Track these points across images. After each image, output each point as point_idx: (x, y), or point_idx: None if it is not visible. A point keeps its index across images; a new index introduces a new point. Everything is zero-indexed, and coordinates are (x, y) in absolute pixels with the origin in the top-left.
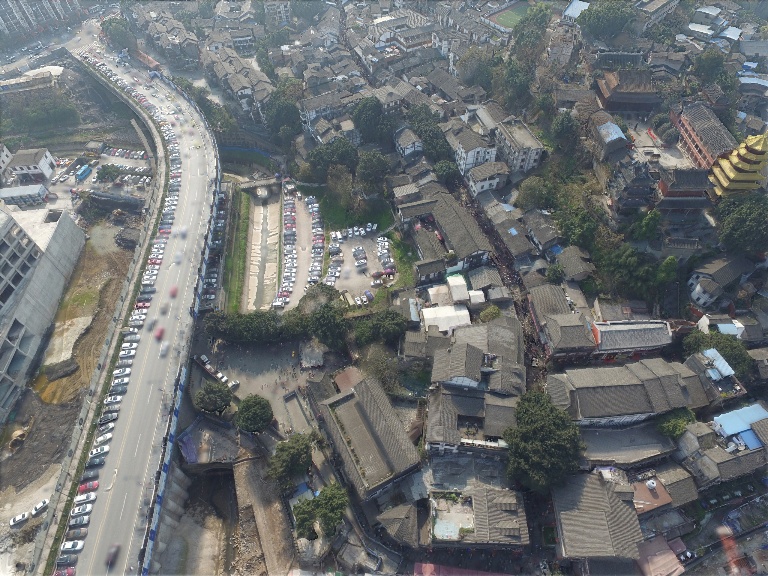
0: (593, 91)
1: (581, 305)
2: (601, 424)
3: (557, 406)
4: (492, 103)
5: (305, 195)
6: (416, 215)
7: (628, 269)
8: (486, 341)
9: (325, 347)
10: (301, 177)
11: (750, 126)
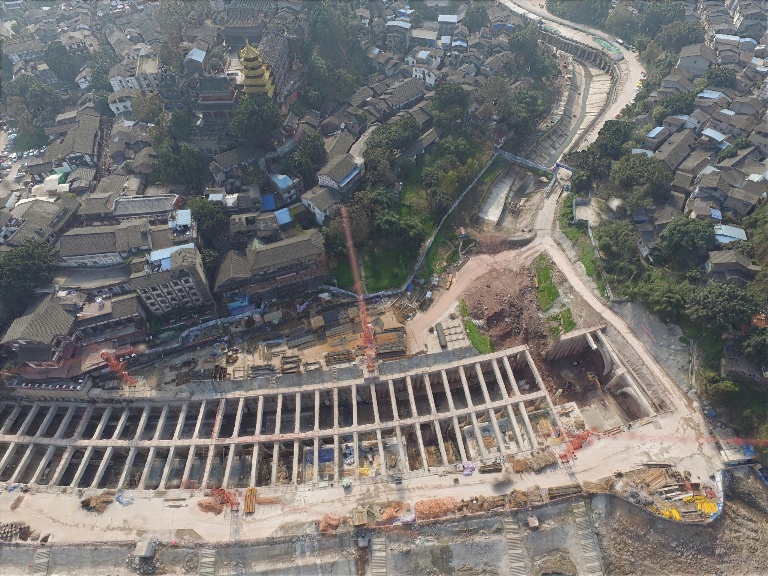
0: (216, 28)
1: (132, 189)
2: (90, 266)
3: (52, 252)
4: (155, 43)
5: (12, 128)
6: (58, 132)
7: (165, 158)
8: (26, 211)
9: None
10: (1, 111)
11: (378, 60)
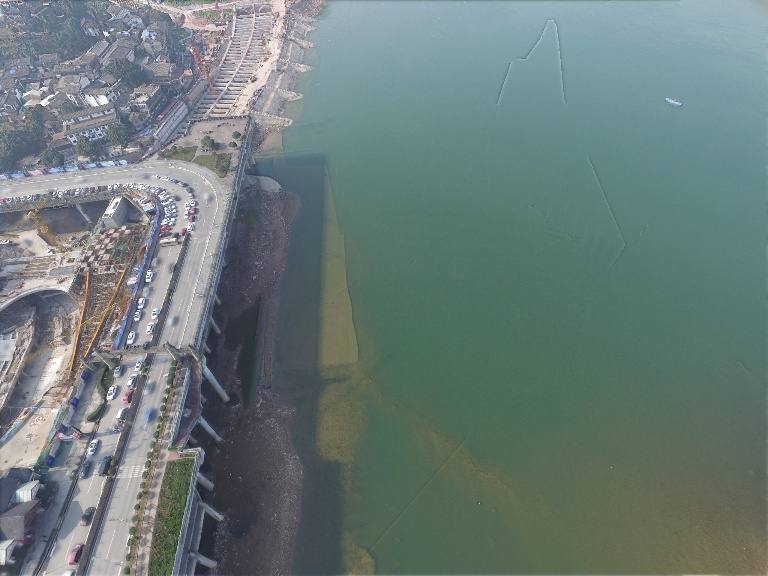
0: None
1: None
2: None
3: None
4: None
5: None
6: None
7: (66, 40)
8: None
9: (30, 157)
10: None
11: None
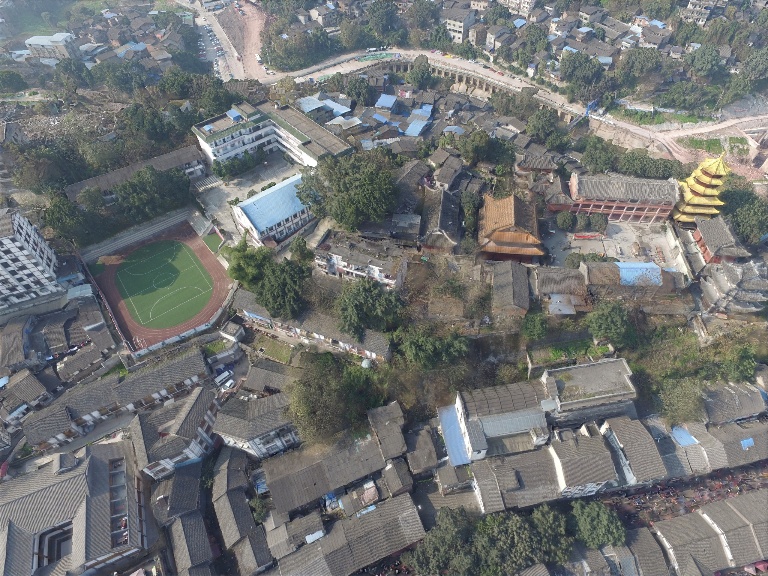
0: (513, 263)
1: None
2: None
3: None
4: (471, 403)
5: None
6: None
7: None
8: None
9: None
10: None
11: None
